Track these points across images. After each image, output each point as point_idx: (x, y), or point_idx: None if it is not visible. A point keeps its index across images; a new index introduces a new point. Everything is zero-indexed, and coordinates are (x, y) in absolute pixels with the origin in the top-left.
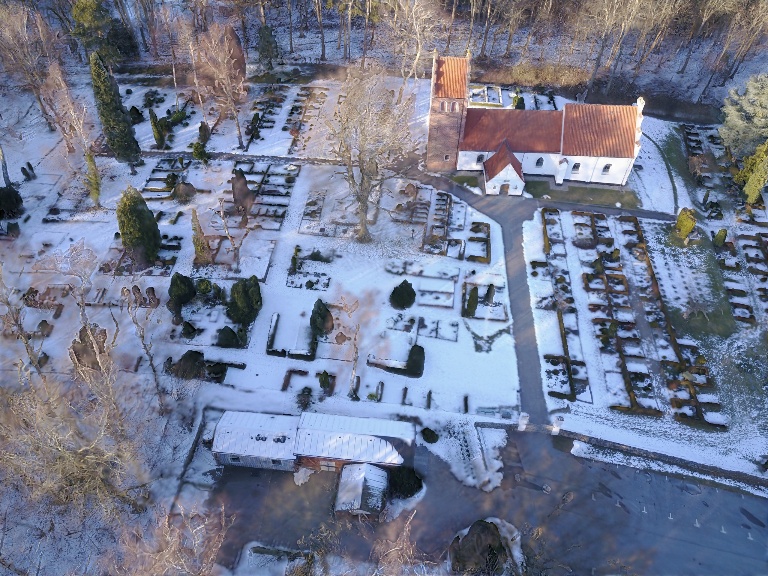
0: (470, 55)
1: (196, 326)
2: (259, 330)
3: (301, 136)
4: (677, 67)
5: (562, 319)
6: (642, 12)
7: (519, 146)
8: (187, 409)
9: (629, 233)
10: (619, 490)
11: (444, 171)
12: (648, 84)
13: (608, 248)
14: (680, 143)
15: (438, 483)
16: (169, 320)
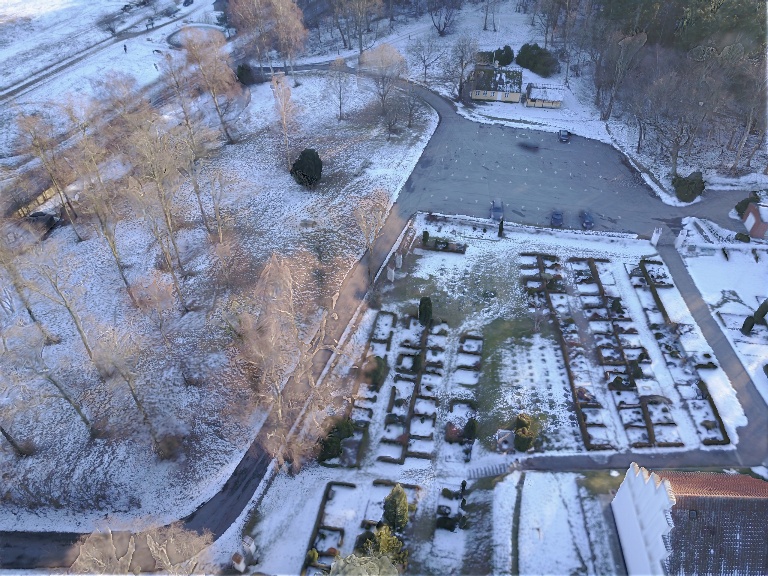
0: None
1: None
2: None
3: None
4: None
5: (666, 312)
6: None
7: None
8: None
9: None
10: (603, 221)
11: None
12: None
13: (624, 401)
14: None
15: (723, 219)
16: None
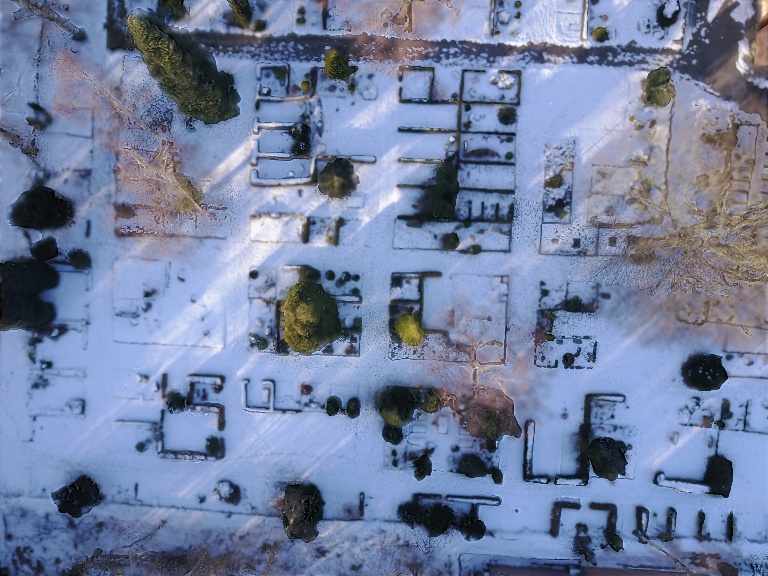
0: None
1: (422, 444)
2: (508, 444)
3: None
4: None
5: None
6: None
7: None
8: (442, 564)
9: None
10: None
11: None
12: None
13: None
14: None
15: None
16: (381, 432)
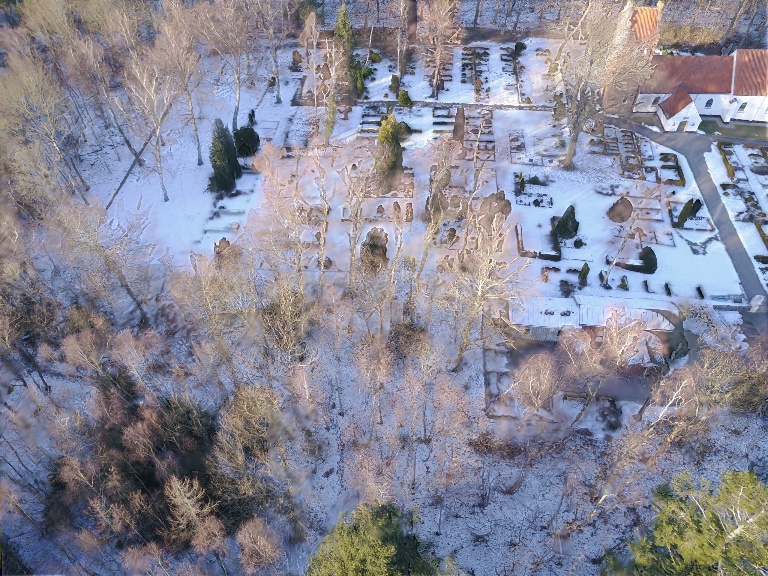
0: (662, 5)
1: None
2: (506, 238)
3: (480, 87)
4: None
5: None
6: None
7: (693, 88)
8: None
9: None
10: None
11: (621, 113)
12: None
13: None
14: None
15: None
16: None
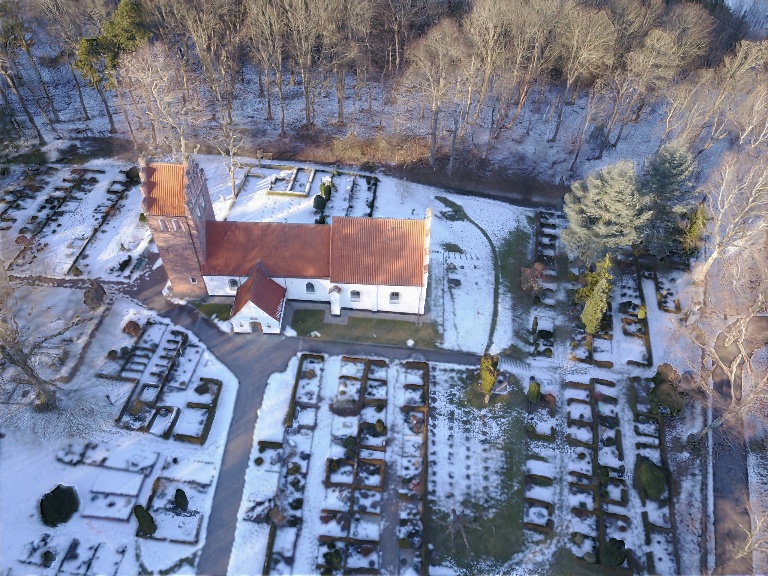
0: (184, 162)
1: None
2: None
3: (38, 242)
4: (547, 134)
5: (271, 541)
6: (497, 72)
7: (277, 269)
8: None
9: (412, 388)
10: None
11: (193, 296)
12: (505, 158)
13: (377, 413)
14: (528, 240)
15: None
16: None
